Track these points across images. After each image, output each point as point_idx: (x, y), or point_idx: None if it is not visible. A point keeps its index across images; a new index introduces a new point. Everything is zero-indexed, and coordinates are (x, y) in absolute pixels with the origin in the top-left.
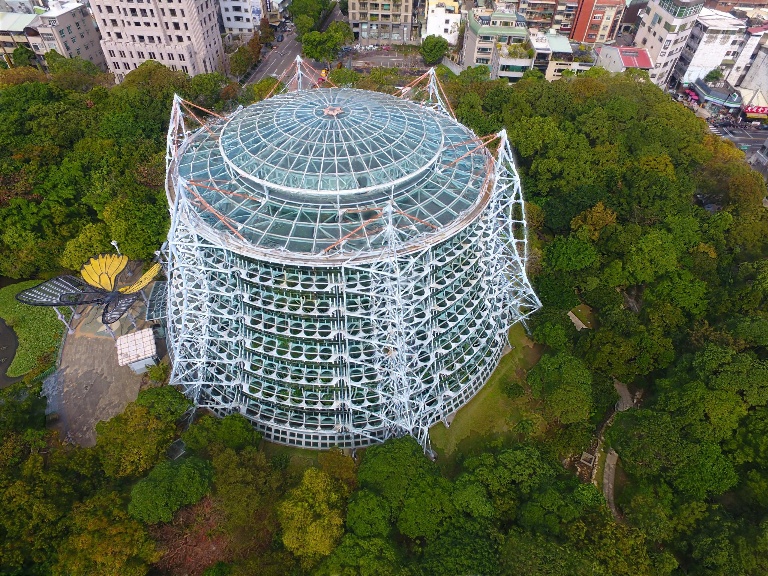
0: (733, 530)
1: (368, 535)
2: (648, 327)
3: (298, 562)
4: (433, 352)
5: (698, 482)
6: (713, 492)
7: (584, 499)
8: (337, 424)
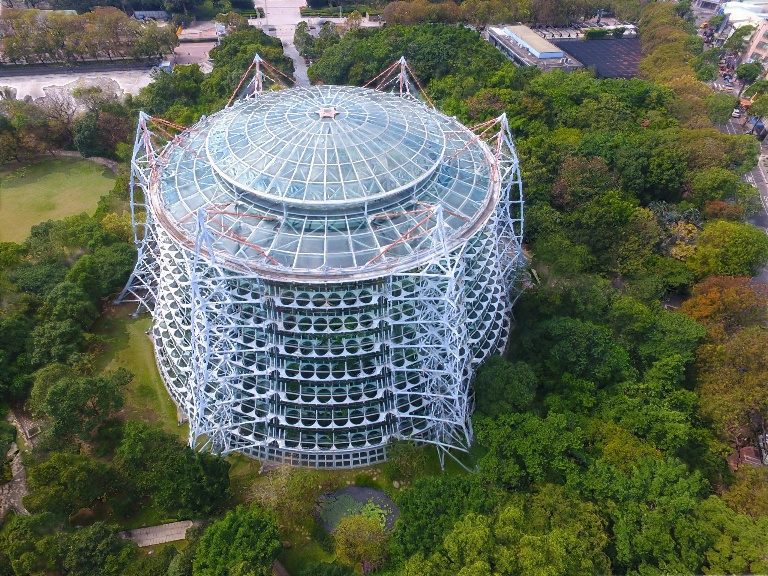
0: None
1: None
2: (35, 552)
3: None
4: None
5: None
6: None
7: None
8: None
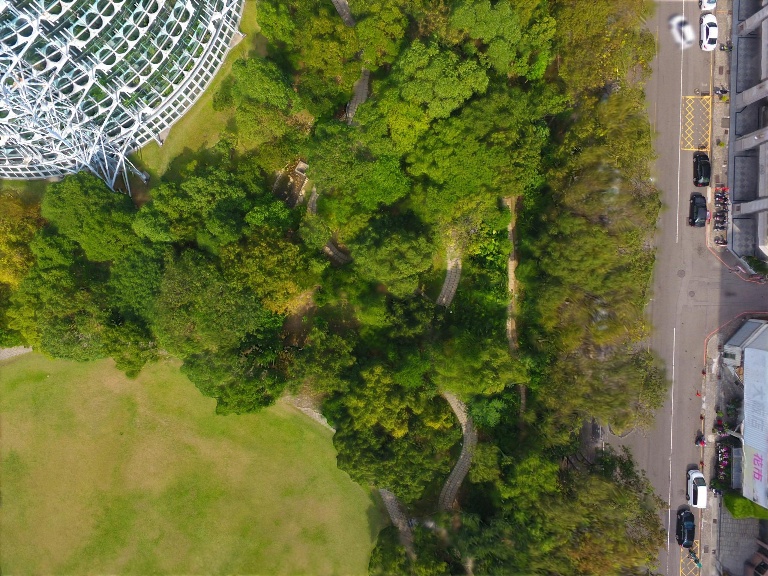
0: (374, 240)
1: (51, 267)
2: (383, 5)
3: (8, 286)
4: (90, 70)
5: (370, 196)
6: (385, 202)
7: (254, 221)
8: (25, 157)
